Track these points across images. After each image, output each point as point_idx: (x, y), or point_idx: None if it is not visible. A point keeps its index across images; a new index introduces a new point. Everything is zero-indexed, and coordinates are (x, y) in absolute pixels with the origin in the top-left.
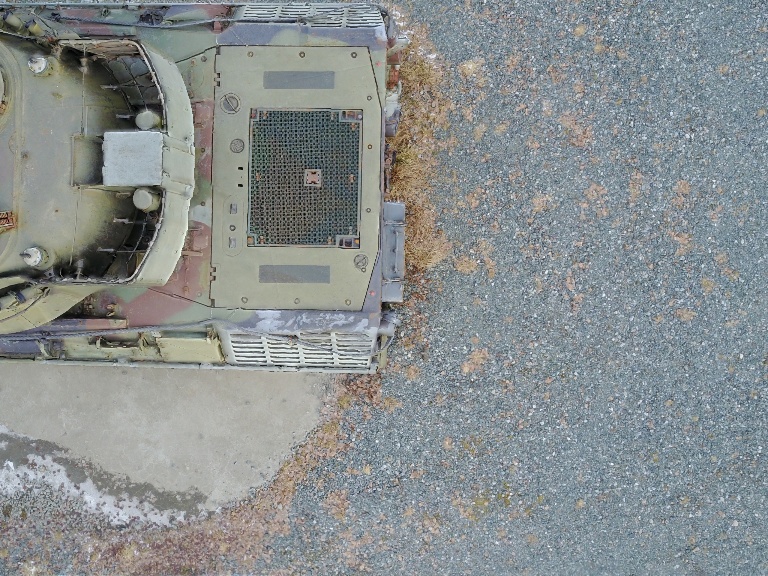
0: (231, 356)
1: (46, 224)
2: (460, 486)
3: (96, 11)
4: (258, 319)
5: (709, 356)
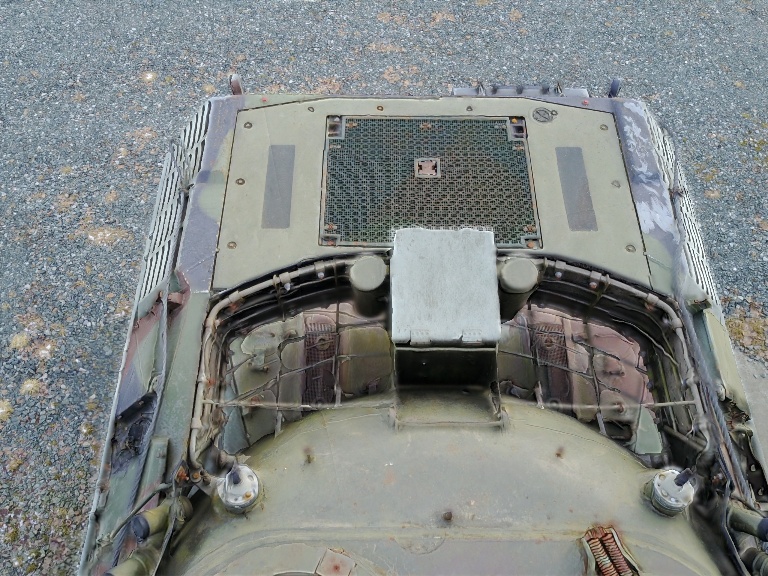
0: (714, 309)
1: (590, 479)
2: (761, 183)
3: (95, 571)
4: (657, 231)
5: (554, 1)
